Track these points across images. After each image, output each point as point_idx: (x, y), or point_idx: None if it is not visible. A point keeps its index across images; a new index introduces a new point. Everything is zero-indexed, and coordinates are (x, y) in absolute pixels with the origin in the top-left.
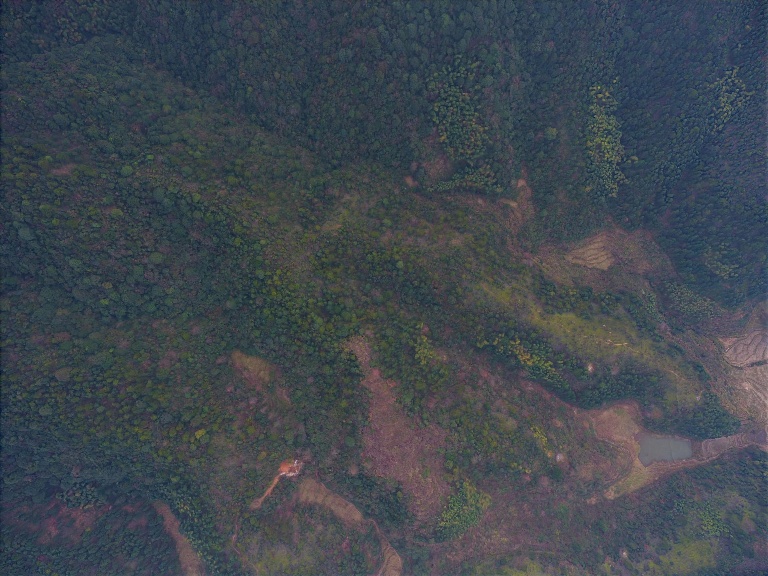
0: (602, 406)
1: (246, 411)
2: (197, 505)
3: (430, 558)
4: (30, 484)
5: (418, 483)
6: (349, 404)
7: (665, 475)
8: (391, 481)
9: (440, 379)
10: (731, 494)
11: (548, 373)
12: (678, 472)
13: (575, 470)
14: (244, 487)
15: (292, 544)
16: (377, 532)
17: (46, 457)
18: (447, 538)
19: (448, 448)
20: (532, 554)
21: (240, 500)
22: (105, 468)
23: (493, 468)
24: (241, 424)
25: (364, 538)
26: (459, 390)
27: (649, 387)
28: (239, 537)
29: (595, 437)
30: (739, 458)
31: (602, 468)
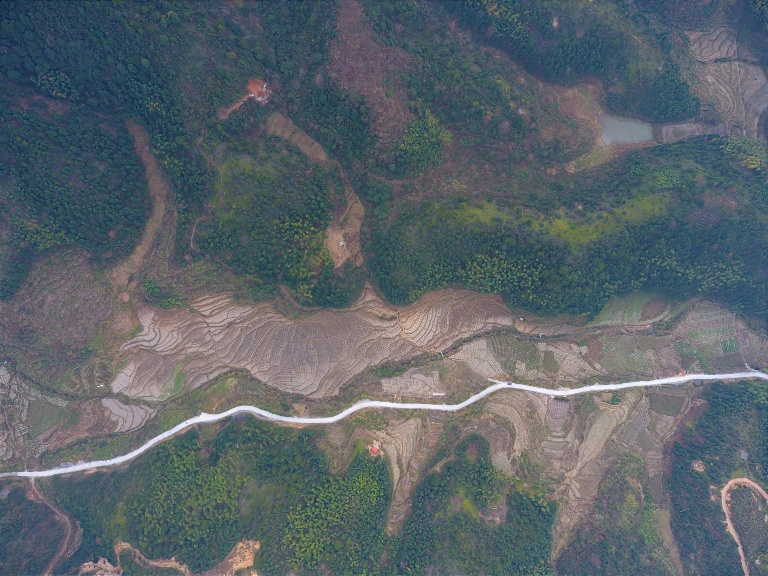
0: (566, 75)
1: (218, 14)
2: (166, 96)
3: (391, 200)
4: (6, 54)
5: (381, 99)
6: (318, 22)
7: (625, 152)
8: (355, 94)
9: (408, 11)
10: (687, 161)
11: (515, 30)
12: (638, 149)
13: (536, 124)
14: (212, 84)
15: (257, 155)
16: (341, 175)
17: (22, 14)
18: (407, 169)
19: (412, 72)
20: (490, 196)
21: (208, 99)
22: (78, 40)
23: (456, 109)
24: (212, 24)
25: (328, 173)
26: (427, 31)
27: (613, 57)
28: (205, 138)
29: (559, 111)
30: (698, 139)
31: (563, 133)
